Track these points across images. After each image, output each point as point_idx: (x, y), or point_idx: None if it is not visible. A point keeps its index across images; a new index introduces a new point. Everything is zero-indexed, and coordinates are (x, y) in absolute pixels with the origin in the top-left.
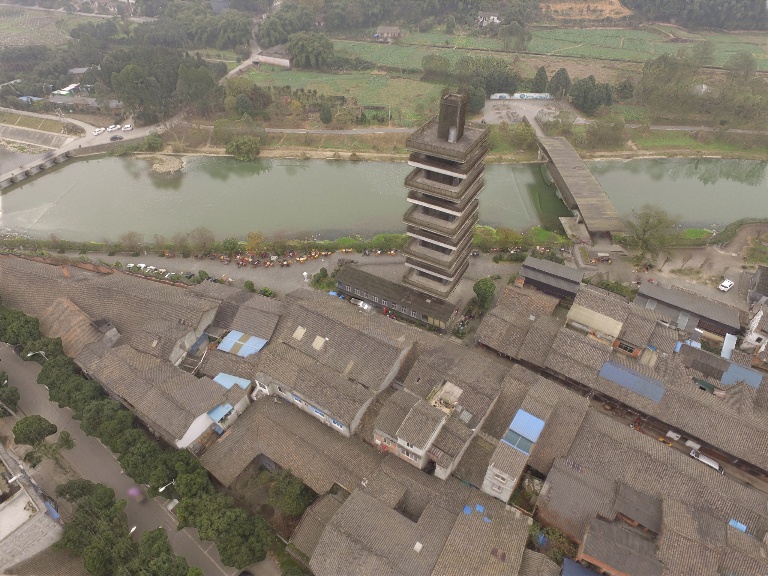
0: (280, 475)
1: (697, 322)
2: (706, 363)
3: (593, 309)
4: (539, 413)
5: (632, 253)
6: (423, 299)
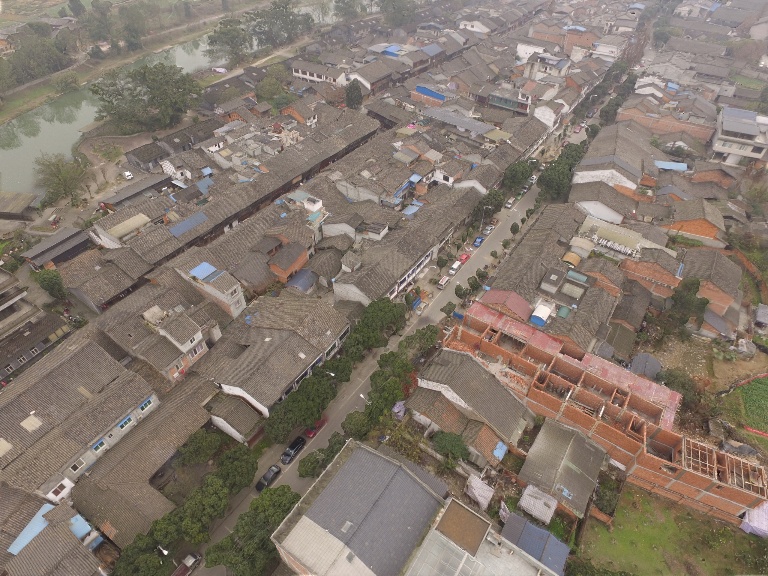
0: (179, 457)
1: (155, 191)
2: (190, 193)
3: (119, 223)
4: (195, 266)
5: (61, 205)
6: (21, 338)
